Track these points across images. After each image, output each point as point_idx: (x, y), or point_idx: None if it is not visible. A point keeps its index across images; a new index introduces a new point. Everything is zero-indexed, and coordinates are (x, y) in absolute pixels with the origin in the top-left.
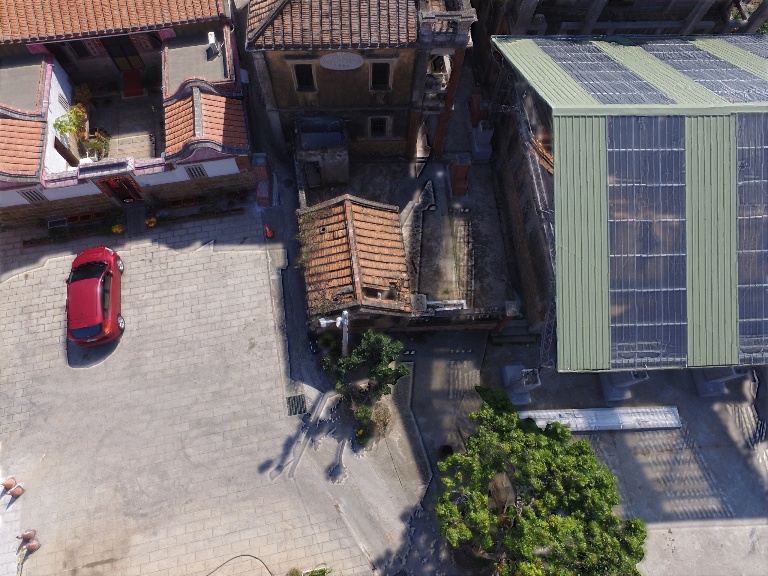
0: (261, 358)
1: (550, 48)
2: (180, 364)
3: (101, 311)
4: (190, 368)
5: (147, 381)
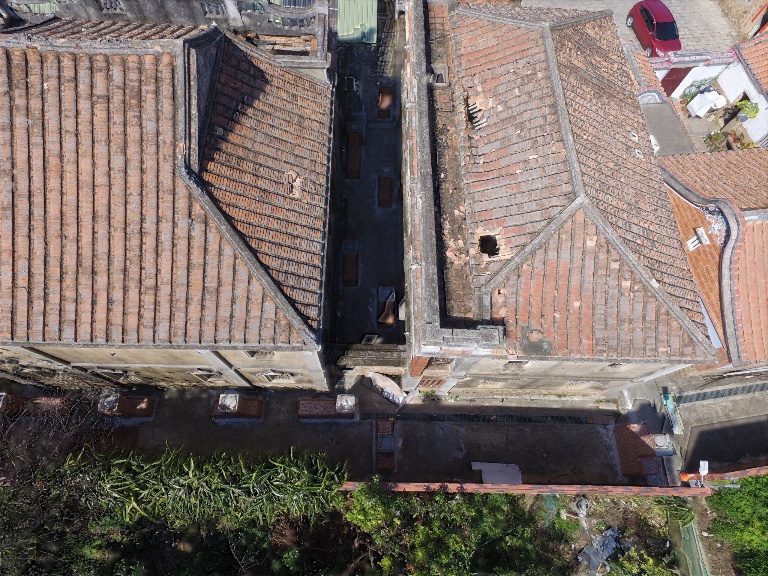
0: (532, 4)
1: (330, 0)
2: (583, 6)
3: (645, 8)
4: (576, 3)
5: (600, 0)
